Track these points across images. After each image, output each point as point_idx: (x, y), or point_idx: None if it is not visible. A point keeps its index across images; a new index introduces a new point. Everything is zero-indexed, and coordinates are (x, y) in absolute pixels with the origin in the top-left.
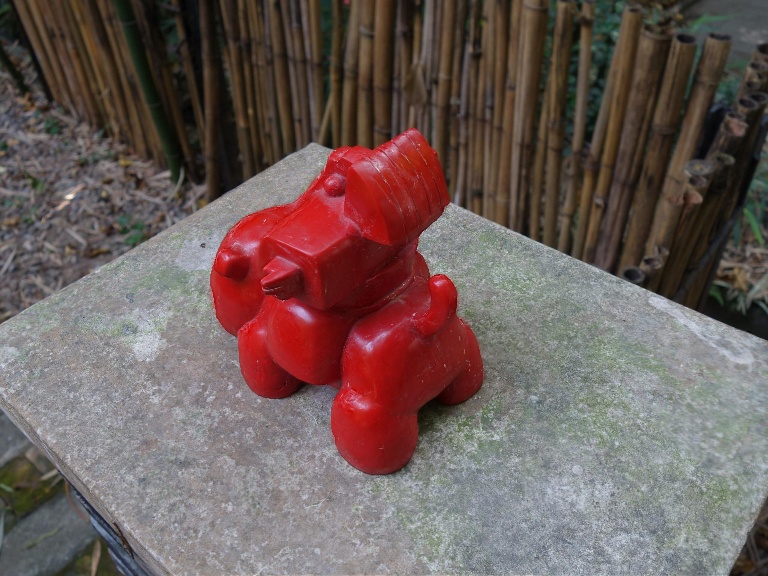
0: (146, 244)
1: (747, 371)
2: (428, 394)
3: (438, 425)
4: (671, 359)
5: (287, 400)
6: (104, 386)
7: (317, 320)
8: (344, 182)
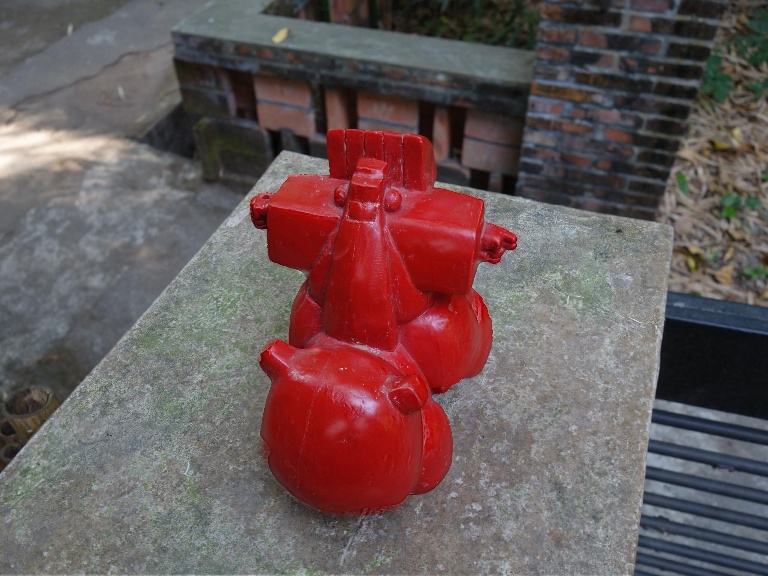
0: None
1: None
2: None
3: None
4: None
5: None
6: None
7: None
8: None
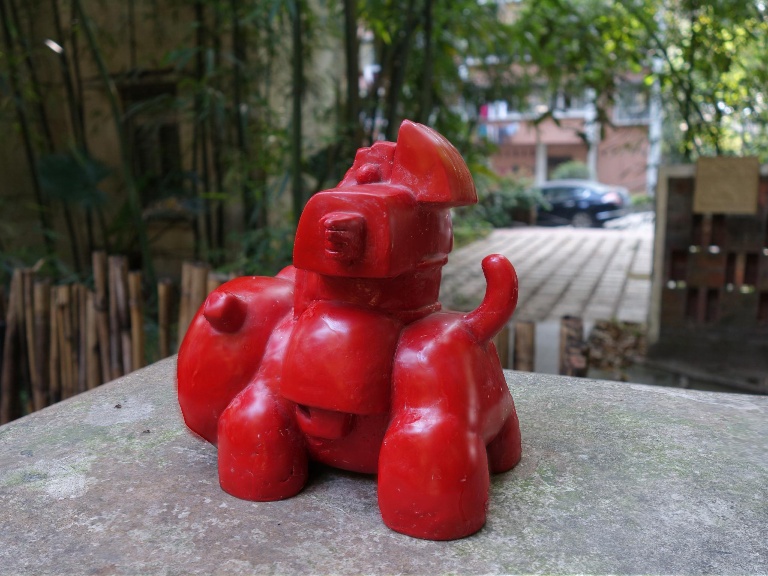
0: (38, 413)
1: (760, 413)
2: (489, 428)
3: (497, 490)
4: (688, 415)
5: (293, 500)
6: (8, 529)
7: (360, 324)
8: (378, 170)
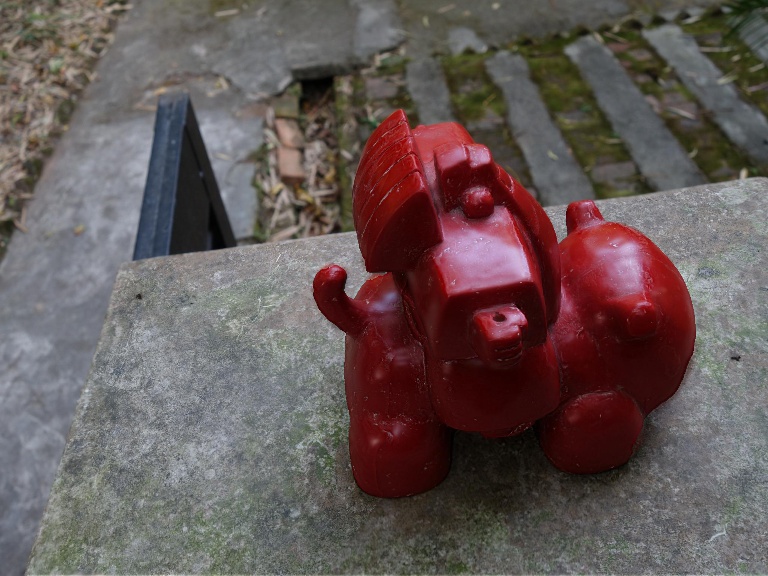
0: None
1: None
2: None
3: None
4: None
5: None
6: None
7: None
8: None
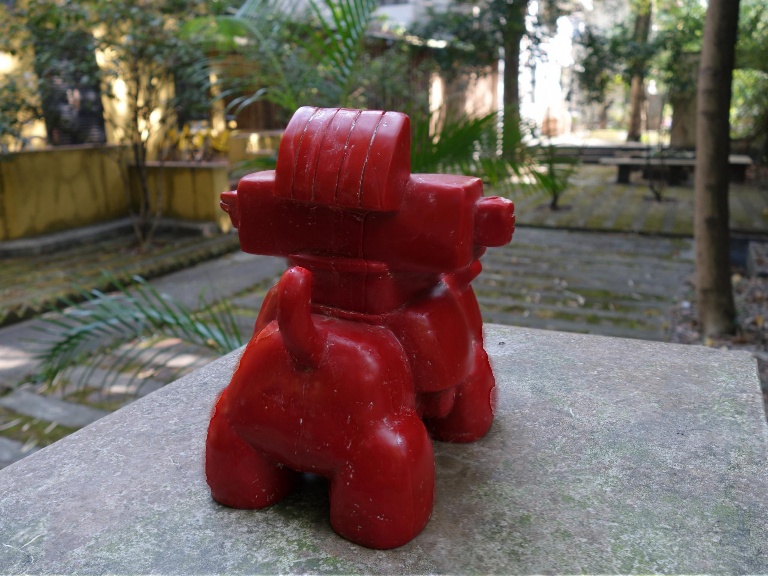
0: None
1: None
2: (282, 447)
3: (295, 522)
4: None
5: None
6: None
7: None
8: None
